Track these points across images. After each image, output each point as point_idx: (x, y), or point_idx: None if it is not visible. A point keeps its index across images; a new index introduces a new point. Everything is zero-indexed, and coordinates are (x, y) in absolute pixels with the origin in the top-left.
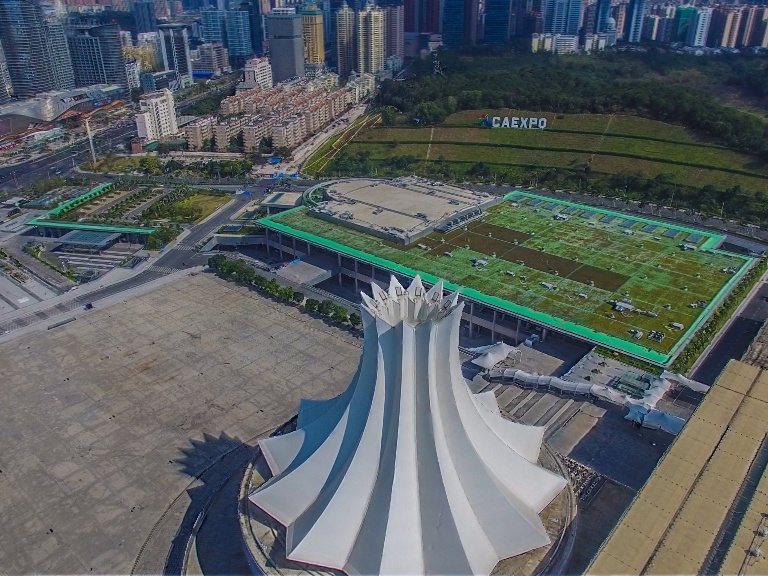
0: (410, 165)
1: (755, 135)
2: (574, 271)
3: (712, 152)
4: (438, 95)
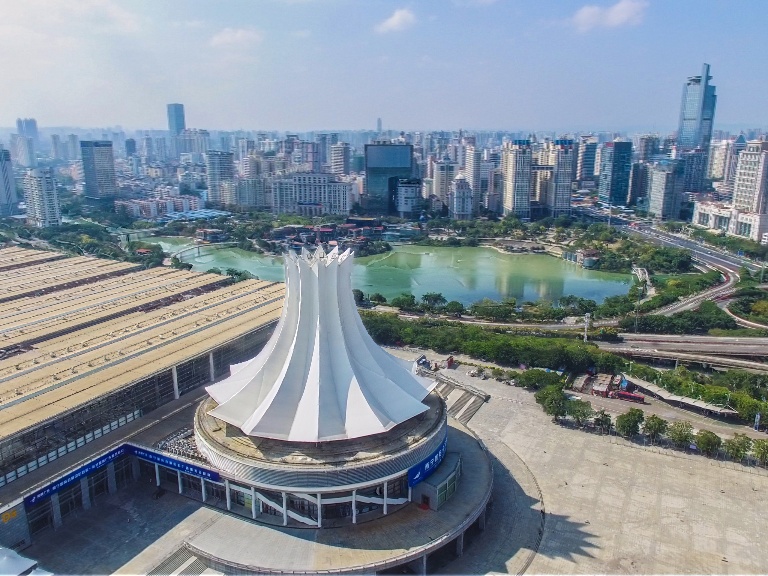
0: None
1: None
2: None
3: None
4: None
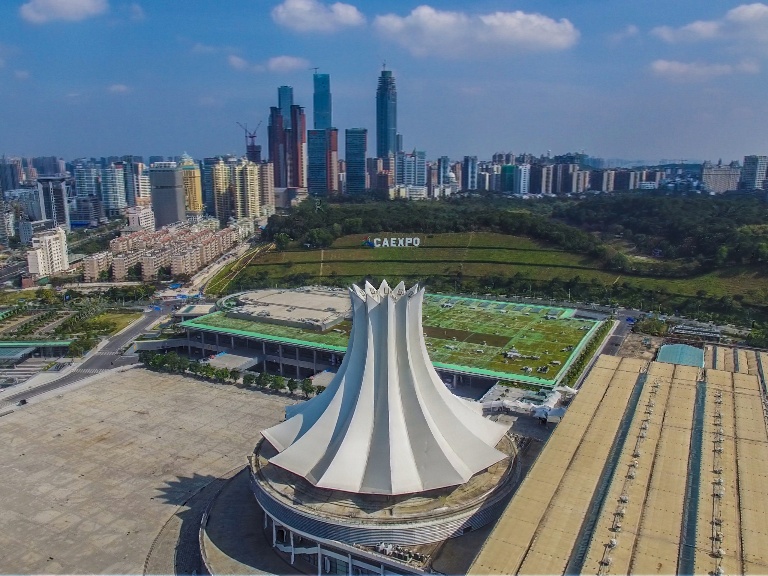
0: (307, 280)
1: (583, 240)
2: (468, 337)
3: (554, 255)
4: (323, 225)
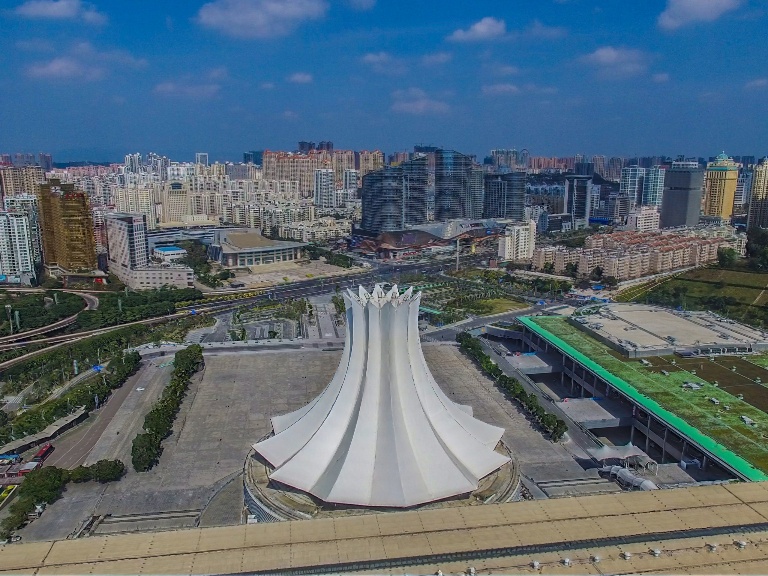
0: (727, 306)
1: None
2: None
3: None
4: None
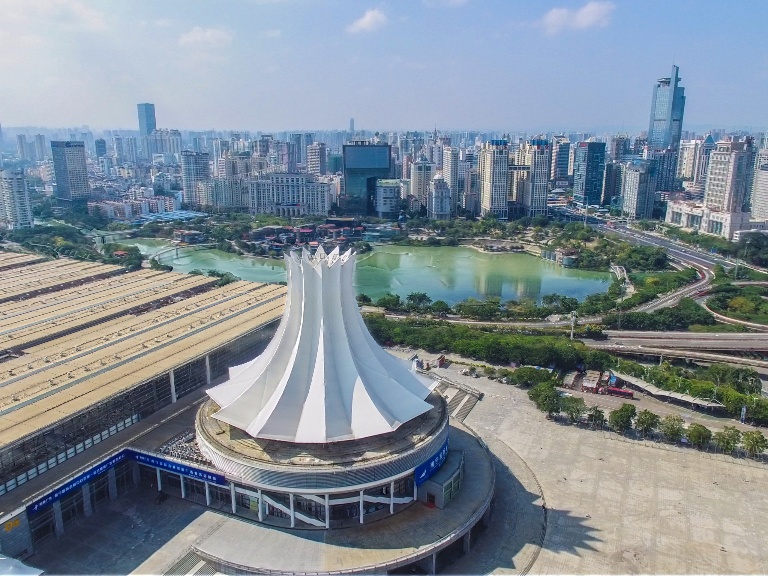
0: None
1: None
2: None
3: None
4: None
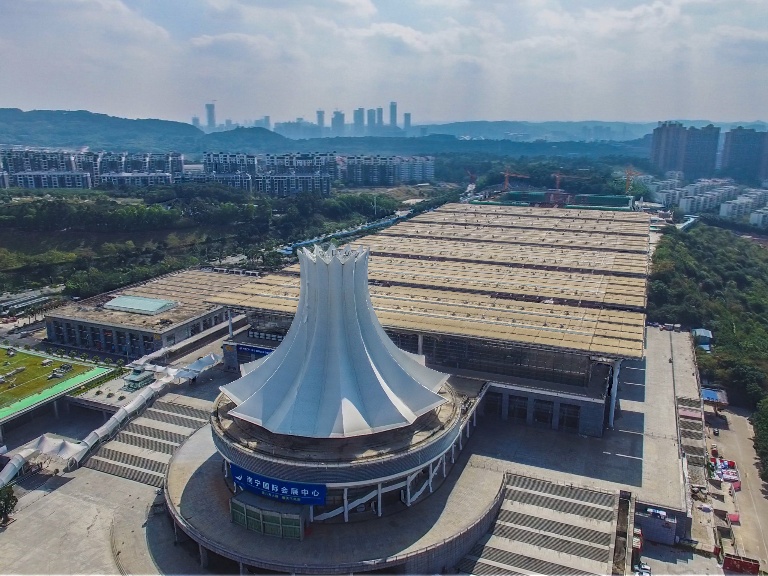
0: None
1: None
2: None
3: None
4: None
